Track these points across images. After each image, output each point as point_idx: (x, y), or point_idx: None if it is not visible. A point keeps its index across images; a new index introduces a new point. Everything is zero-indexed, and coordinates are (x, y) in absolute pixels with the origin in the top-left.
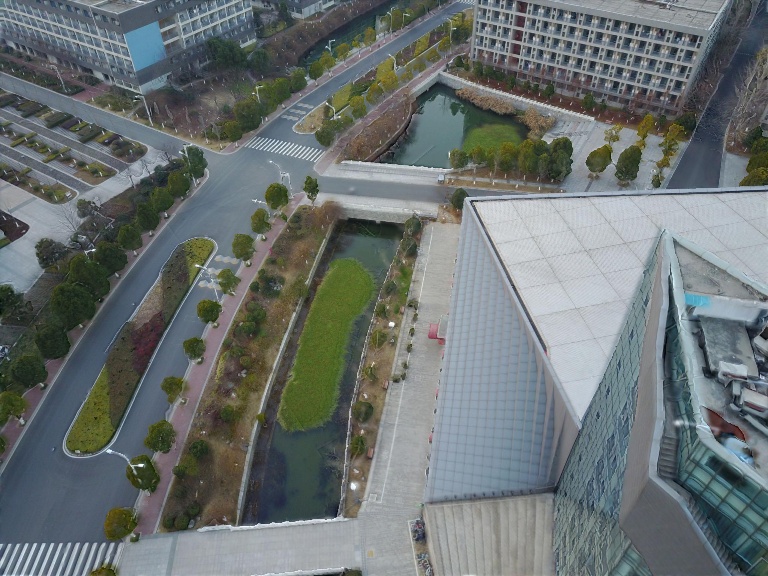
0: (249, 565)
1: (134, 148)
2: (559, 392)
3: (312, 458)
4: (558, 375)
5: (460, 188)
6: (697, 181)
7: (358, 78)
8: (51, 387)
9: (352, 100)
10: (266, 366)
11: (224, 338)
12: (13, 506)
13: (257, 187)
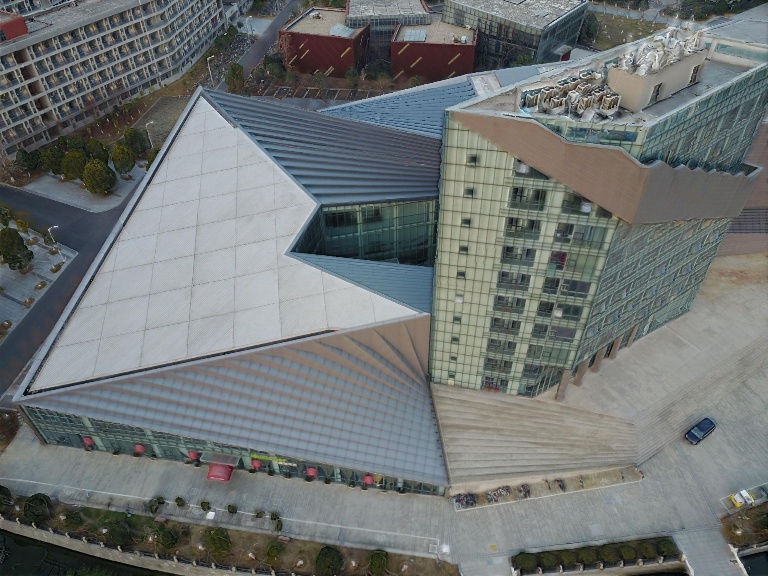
0: None
1: None
2: (387, 324)
3: None
4: (366, 324)
5: None
6: (56, 217)
7: None
8: None
9: None
10: None
11: None
12: None
13: None
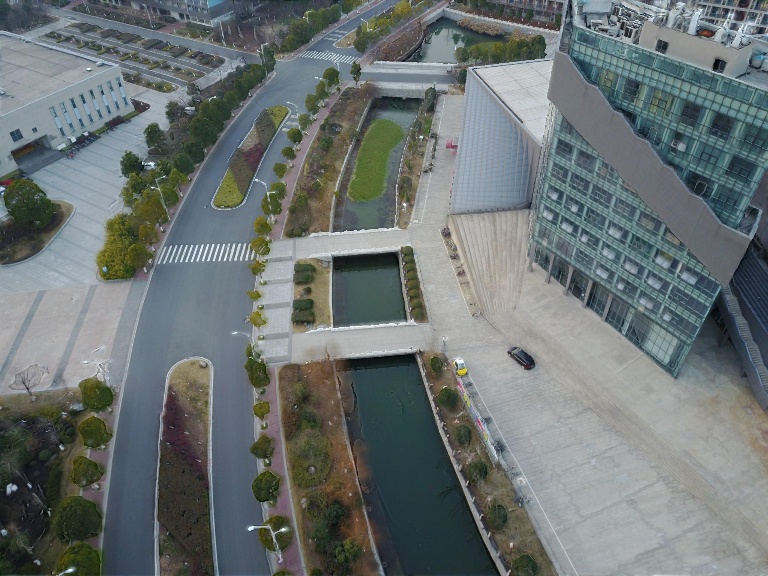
0: (343, 248)
1: (216, 58)
2: (530, 136)
3: (373, 214)
4: (530, 130)
5: (464, 68)
6: None
7: (380, 13)
8: (195, 180)
9: (379, 22)
10: (336, 170)
11: (306, 155)
12: (188, 230)
13: (313, 78)
